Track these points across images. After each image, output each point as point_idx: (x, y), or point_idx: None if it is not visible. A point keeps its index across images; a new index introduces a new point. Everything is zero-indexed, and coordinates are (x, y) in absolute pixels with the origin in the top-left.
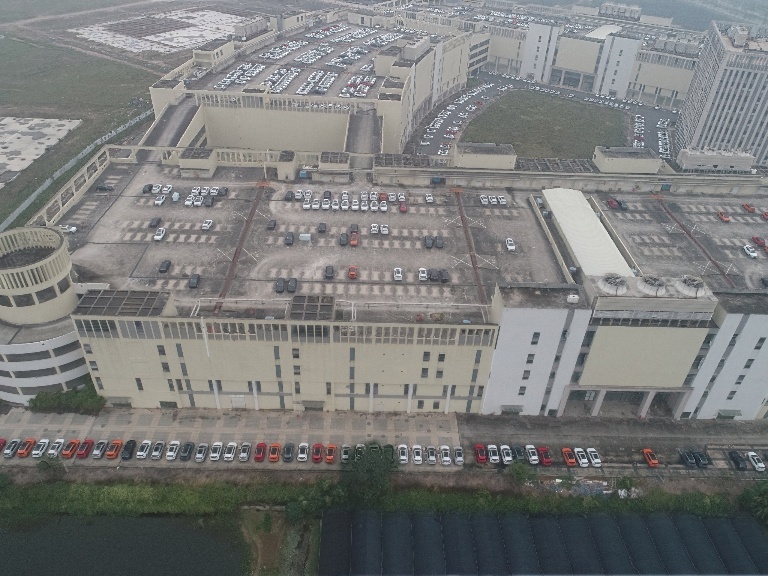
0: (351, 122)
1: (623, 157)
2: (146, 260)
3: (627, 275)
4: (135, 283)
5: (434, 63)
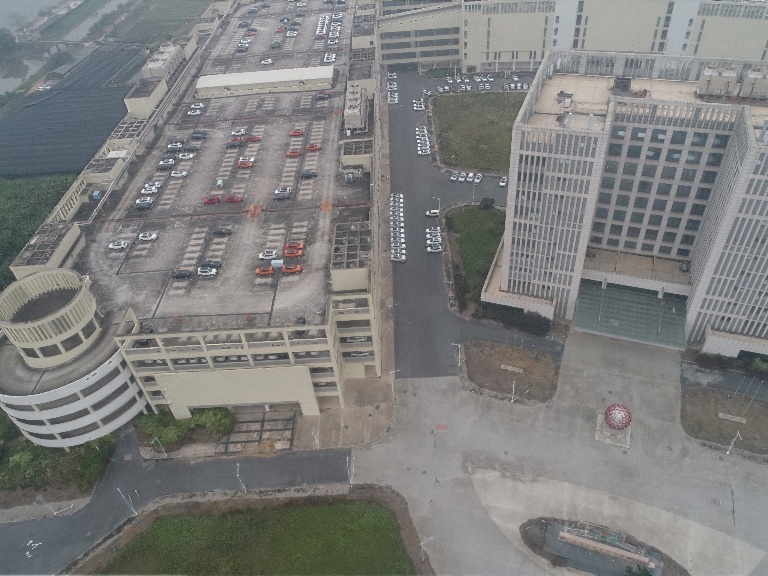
0: (448, 7)
1: (358, 72)
2: (273, 3)
3: (214, 83)
4: (256, 5)
5: (670, 18)
